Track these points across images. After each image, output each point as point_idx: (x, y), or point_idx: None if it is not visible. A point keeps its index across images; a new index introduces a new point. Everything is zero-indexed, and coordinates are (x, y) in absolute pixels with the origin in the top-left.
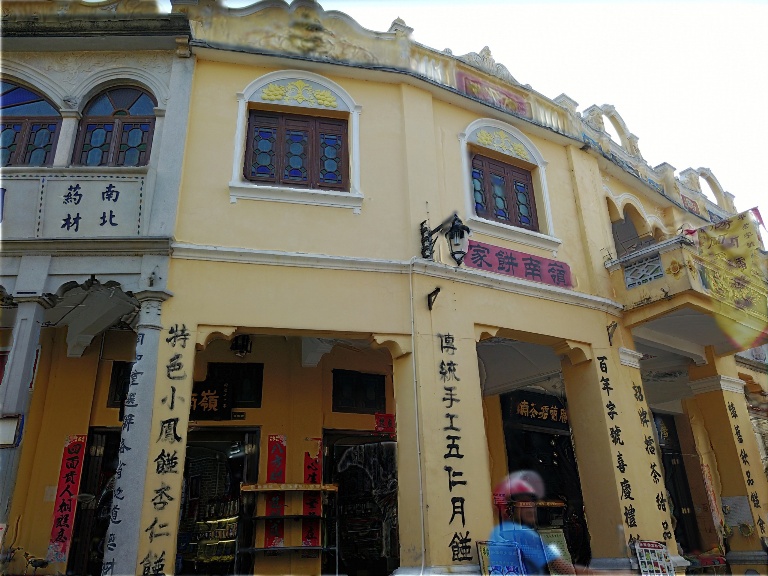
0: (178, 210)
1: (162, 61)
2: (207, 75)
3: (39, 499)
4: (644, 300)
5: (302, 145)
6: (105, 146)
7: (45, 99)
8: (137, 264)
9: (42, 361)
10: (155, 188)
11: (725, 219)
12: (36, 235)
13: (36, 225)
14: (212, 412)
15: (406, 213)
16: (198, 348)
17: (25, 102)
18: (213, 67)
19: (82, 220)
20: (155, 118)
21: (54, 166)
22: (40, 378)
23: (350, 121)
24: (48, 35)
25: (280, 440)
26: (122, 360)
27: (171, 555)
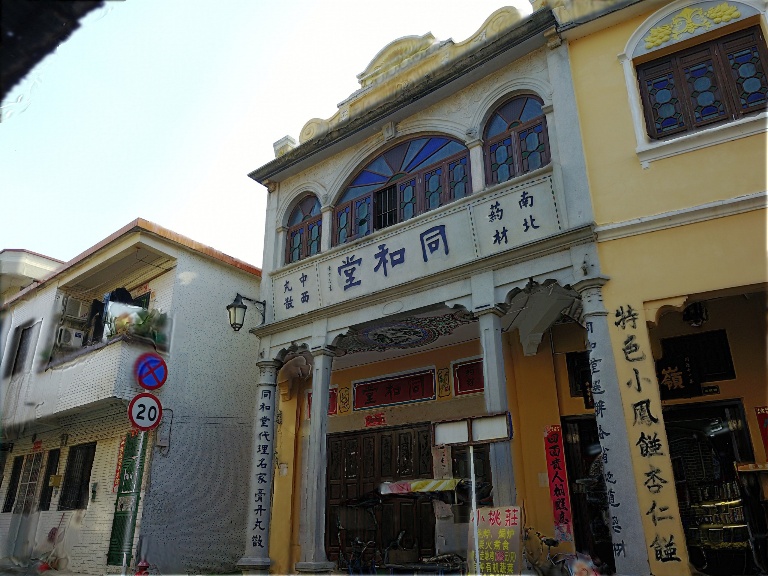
0: (591, 195)
1: (537, 61)
2: (582, 53)
3: (535, 485)
4: None
5: (708, 77)
6: (509, 160)
7: (452, 140)
8: (567, 258)
9: (505, 363)
10: (563, 181)
11: None
12: (476, 256)
13: (474, 248)
14: (679, 390)
15: None
16: (650, 326)
17: (438, 149)
18: (586, 42)
19: (508, 232)
20: (545, 116)
21: (474, 193)
22: (508, 378)
23: (763, 24)
24: (441, 85)
25: None
26: (573, 351)
27: (681, 539)
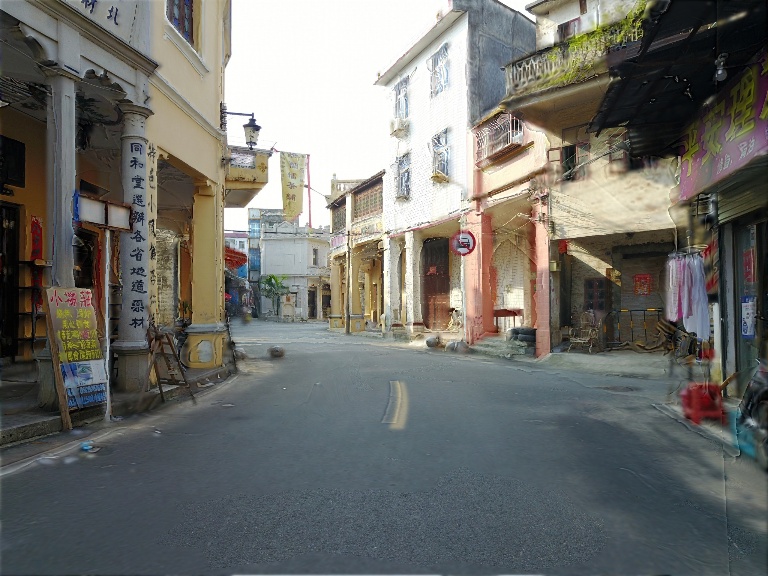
0: None
1: None
2: None
3: None
4: (240, 178)
5: None
6: None
7: None
8: (133, 76)
9: None
10: None
11: (296, 154)
12: None
13: None
14: None
15: (215, 91)
16: None
17: None
18: None
19: (96, 3)
20: None
21: None
22: None
23: None
24: None
25: (38, 221)
26: None
27: None
